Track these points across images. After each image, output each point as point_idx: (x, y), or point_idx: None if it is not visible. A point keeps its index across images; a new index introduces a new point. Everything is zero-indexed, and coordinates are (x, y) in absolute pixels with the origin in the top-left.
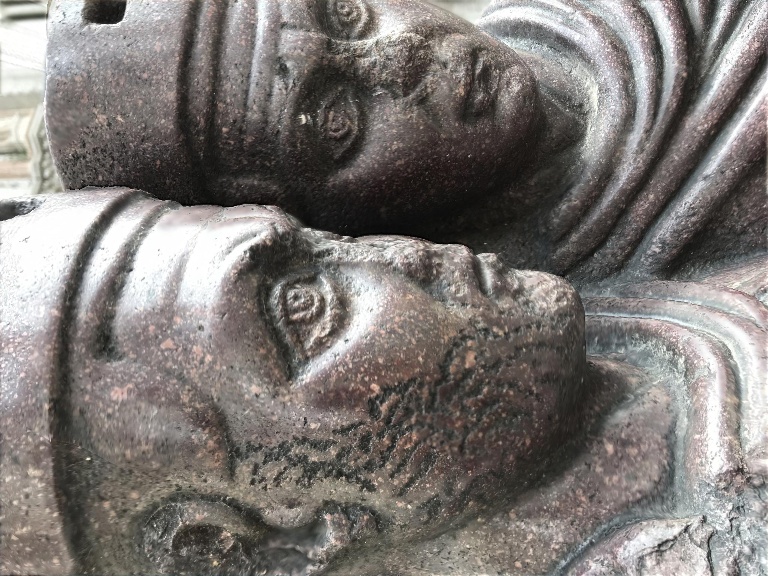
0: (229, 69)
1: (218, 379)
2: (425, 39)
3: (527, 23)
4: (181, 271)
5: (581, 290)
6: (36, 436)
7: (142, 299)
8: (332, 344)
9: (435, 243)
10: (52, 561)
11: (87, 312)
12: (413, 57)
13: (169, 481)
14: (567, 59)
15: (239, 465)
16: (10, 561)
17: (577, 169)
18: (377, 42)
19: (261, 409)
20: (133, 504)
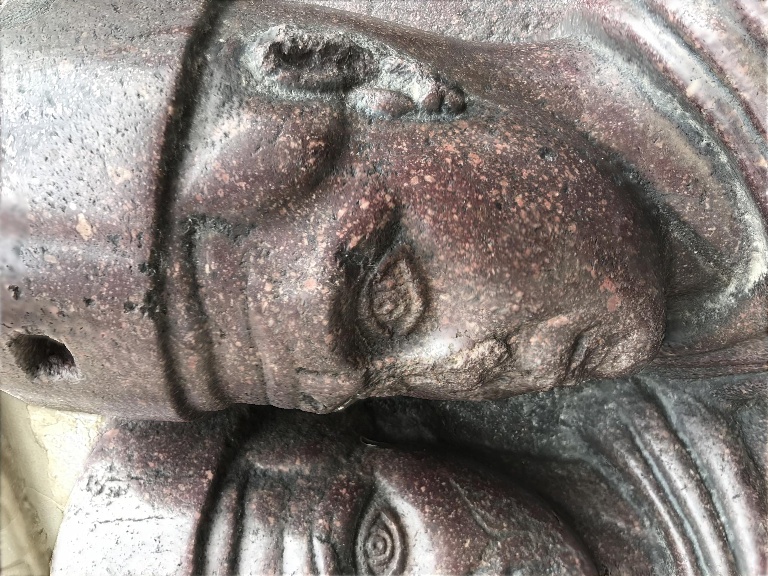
0: (238, 395)
1: None
2: (505, 351)
3: (709, 122)
4: None
5: (649, 376)
6: None
7: None
8: None
9: (483, 553)
10: None
11: None
12: (484, 377)
13: None
14: (747, 199)
15: None
16: None
17: (689, 327)
18: (434, 365)
19: None
20: None
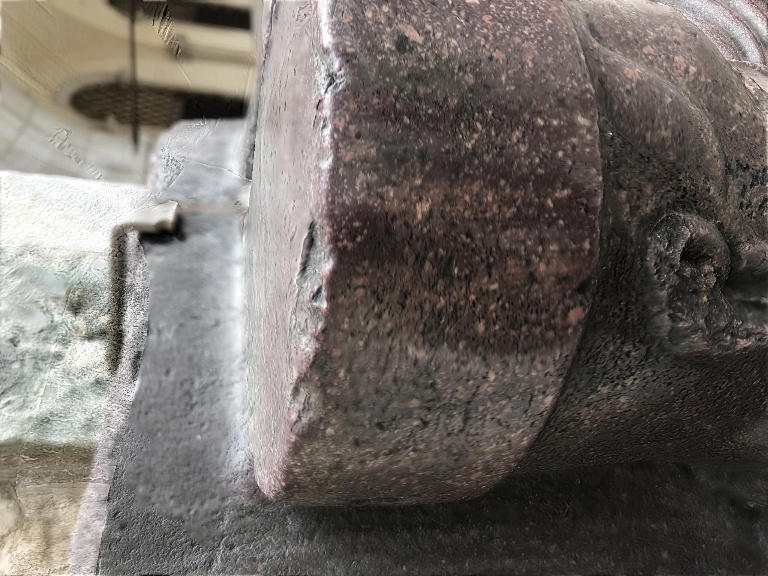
0: None
1: (705, 90)
2: None
3: None
4: (624, 3)
5: None
6: (582, 81)
7: (606, 10)
8: (767, 97)
9: None
10: (584, 244)
11: (568, 0)
12: None
13: (680, 181)
14: None
15: (731, 183)
16: (533, 240)
17: None
18: None
19: (745, 129)
20: (646, 201)
